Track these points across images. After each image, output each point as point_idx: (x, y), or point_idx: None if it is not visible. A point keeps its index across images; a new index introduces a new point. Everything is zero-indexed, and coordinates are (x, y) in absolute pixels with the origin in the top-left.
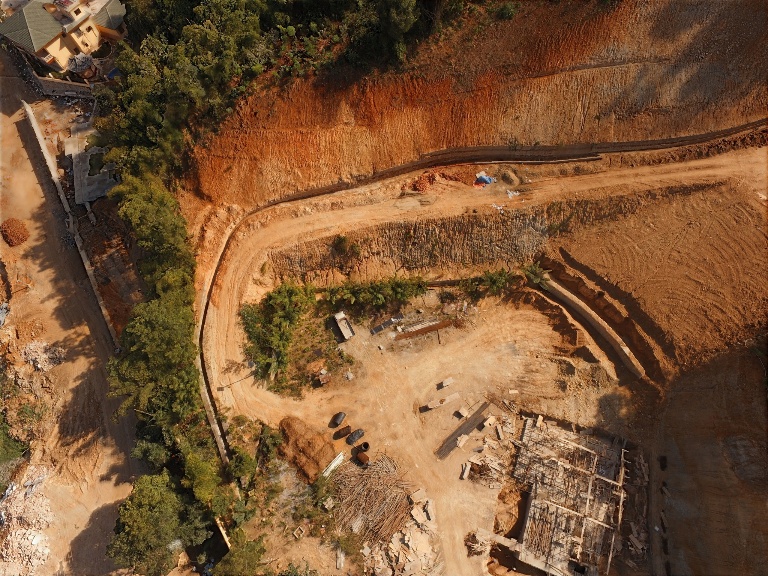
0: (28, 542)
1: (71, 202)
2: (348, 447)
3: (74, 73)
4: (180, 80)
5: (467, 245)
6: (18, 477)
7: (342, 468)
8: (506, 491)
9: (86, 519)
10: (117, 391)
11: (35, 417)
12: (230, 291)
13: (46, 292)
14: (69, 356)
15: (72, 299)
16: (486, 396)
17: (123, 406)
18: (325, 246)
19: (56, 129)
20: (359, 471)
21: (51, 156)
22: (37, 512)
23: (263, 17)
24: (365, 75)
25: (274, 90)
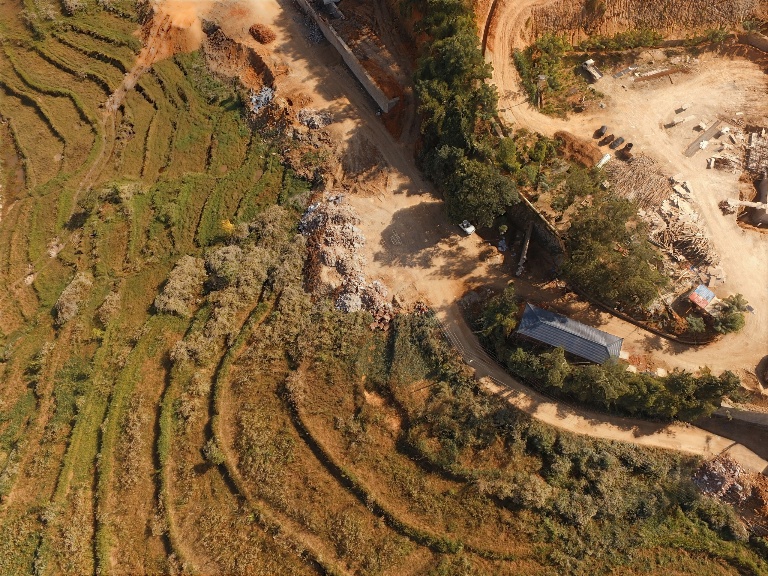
0: (349, 230)
1: (312, 8)
2: (612, 151)
3: None
4: None
5: (693, 7)
6: (316, 200)
7: (611, 163)
8: (744, 177)
9: (390, 218)
10: (428, 104)
11: (319, 160)
12: (502, 39)
13: (304, 75)
14: (337, 118)
15: (328, 79)
16: (717, 117)
17: (439, 110)
18: (579, 4)
19: None
20: (625, 164)
21: None
22: (350, 212)
23: None
24: None
25: None
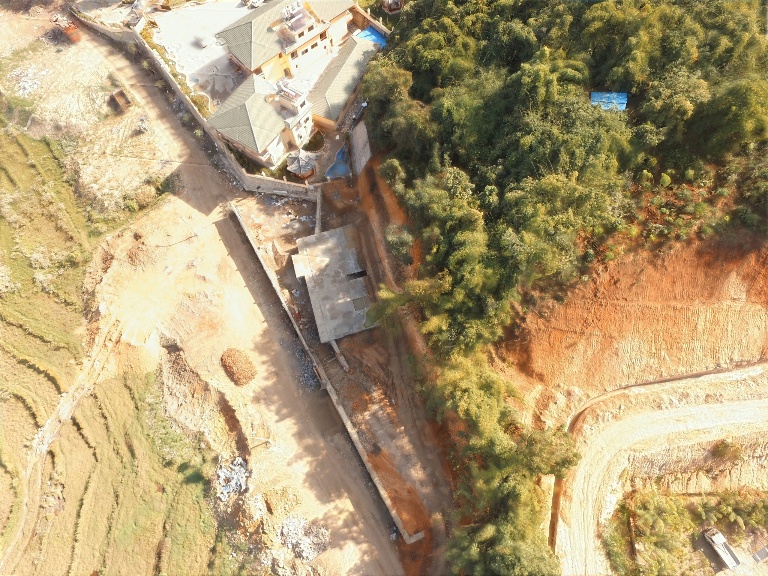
0: None
1: (305, 334)
2: None
3: (291, 172)
4: (541, 247)
5: None
6: None
7: None
8: None
9: None
10: None
11: None
12: (583, 504)
13: (291, 450)
14: (334, 540)
15: (324, 461)
16: None
17: None
18: (701, 450)
19: (269, 236)
20: None
21: (270, 272)
22: None
23: (618, 157)
24: (767, 242)
25: (644, 255)
